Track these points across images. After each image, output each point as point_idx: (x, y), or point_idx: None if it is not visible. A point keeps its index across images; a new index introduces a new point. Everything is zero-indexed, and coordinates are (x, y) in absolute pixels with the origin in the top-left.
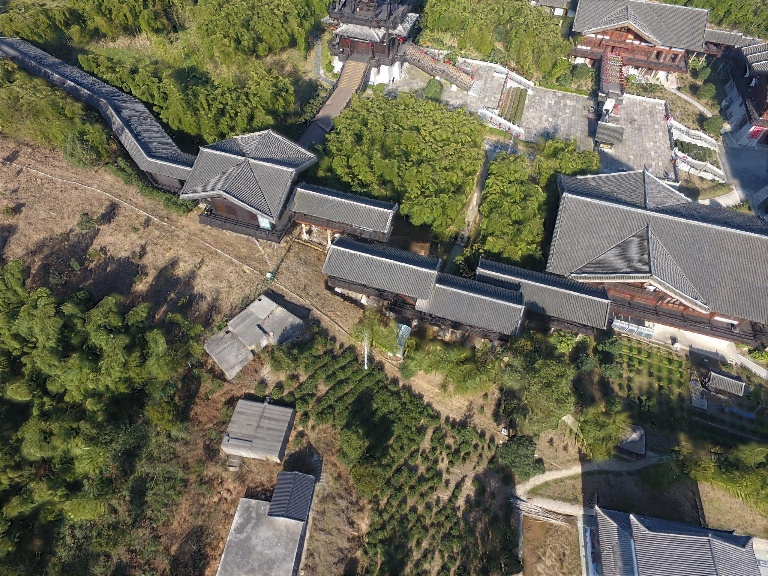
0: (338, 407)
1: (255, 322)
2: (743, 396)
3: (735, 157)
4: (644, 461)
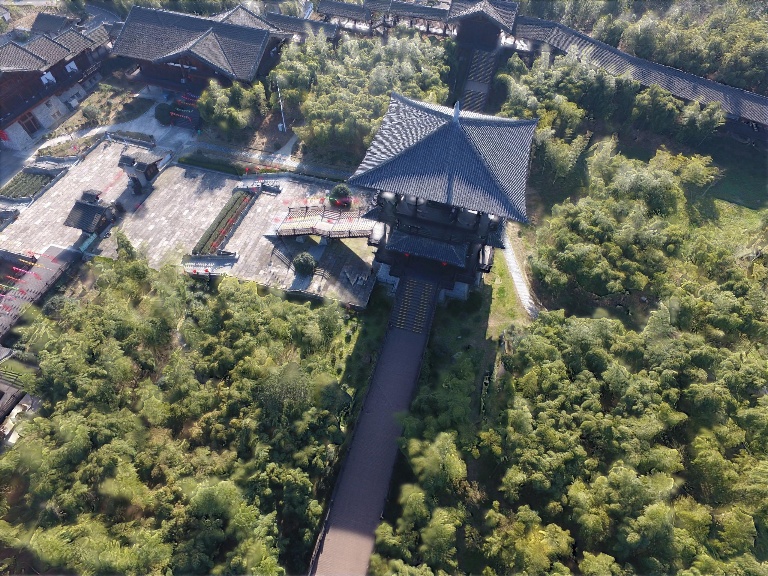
0: None
1: None
2: None
3: None
4: None
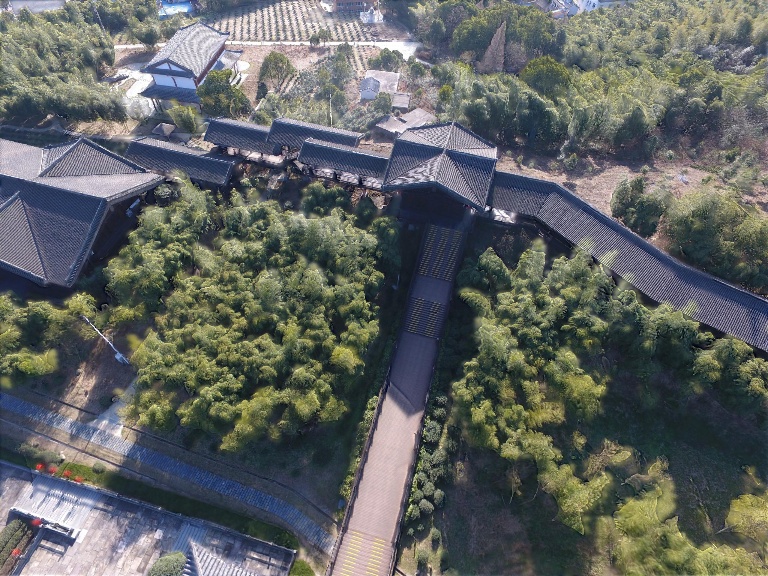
0: (349, 116)
1: (408, 123)
2: None
3: None
4: None
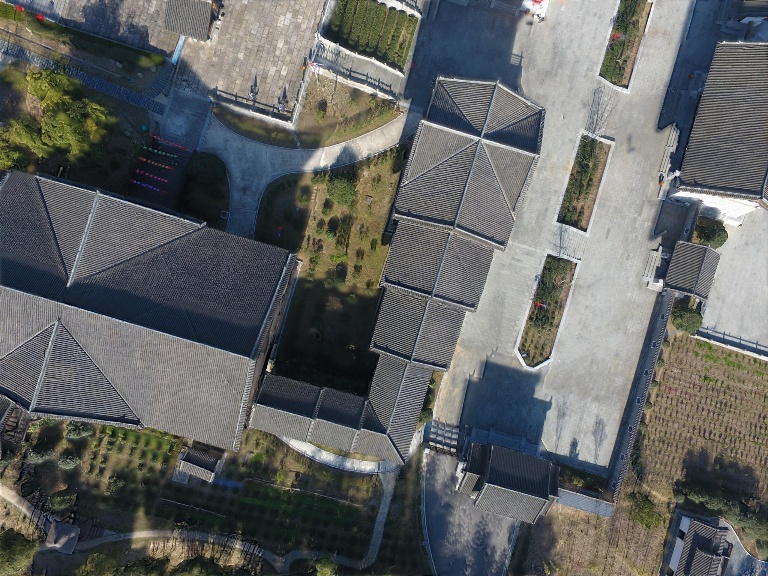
0: None
1: None
2: (239, 464)
3: (445, 30)
4: (99, 540)
